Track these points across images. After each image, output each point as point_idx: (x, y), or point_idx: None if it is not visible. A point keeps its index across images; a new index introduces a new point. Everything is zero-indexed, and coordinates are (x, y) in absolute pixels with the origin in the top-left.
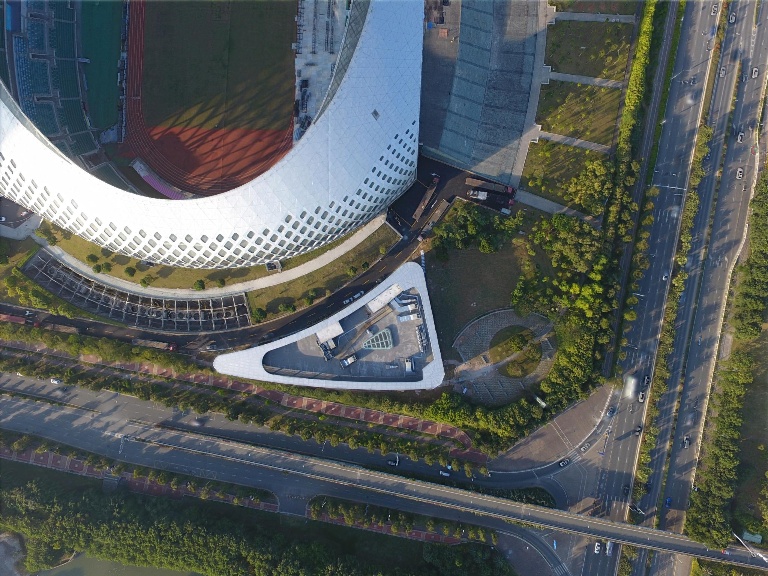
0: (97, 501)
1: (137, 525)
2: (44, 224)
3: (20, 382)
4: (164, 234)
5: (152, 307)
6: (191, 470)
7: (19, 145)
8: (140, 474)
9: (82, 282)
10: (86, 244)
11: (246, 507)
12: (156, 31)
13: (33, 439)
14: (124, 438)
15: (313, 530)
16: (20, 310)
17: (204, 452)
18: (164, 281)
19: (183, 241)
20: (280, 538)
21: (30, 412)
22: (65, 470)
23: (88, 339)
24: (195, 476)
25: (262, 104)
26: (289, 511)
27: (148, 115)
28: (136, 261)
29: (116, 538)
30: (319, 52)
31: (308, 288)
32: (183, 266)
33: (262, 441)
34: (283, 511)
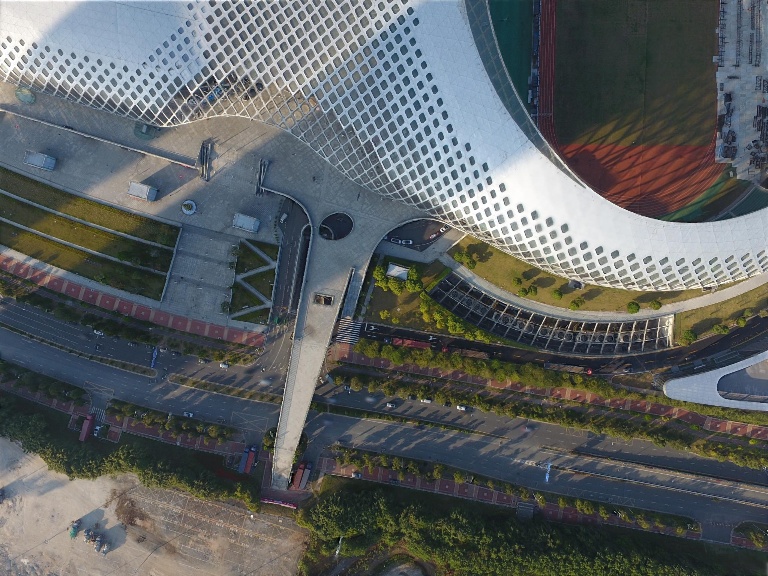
0: (526, 532)
1: (581, 557)
2: (457, 247)
3: (423, 409)
4: (657, 258)
5: (569, 330)
6: (608, 497)
7: (523, 169)
8: (567, 503)
9: (484, 305)
10: (505, 267)
11: (667, 535)
12: (568, 46)
13: (445, 468)
14: (536, 465)
15: (742, 558)
16: (423, 335)
17: (623, 479)
18: (587, 303)
19: (673, 264)
20: (720, 568)
21: (434, 440)
22: (475, 499)
23: (511, 365)
24: (612, 504)
25: (682, 119)
26: (712, 539)
27: (561, 133)
28: (561, 283)
29: (556, 570)
30: (742, 65)
31: (739, 308)
32: (638, 289)
33: (683, 467)
34: (706, 539)
